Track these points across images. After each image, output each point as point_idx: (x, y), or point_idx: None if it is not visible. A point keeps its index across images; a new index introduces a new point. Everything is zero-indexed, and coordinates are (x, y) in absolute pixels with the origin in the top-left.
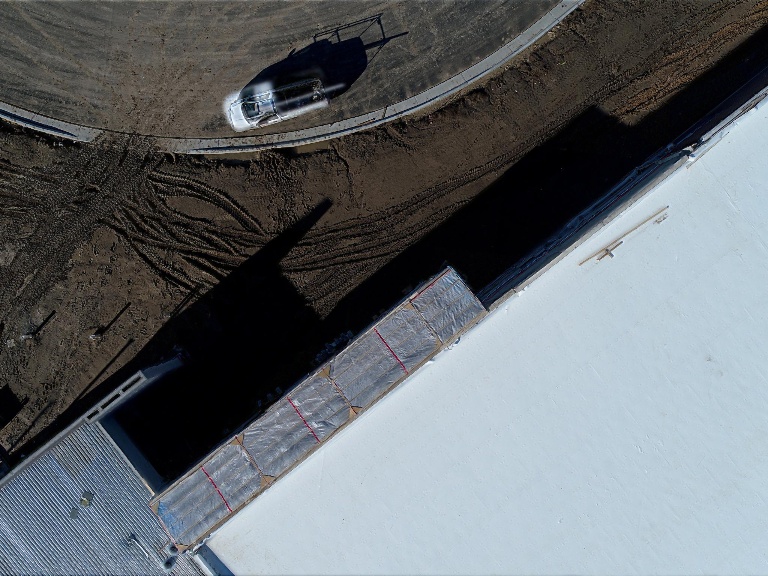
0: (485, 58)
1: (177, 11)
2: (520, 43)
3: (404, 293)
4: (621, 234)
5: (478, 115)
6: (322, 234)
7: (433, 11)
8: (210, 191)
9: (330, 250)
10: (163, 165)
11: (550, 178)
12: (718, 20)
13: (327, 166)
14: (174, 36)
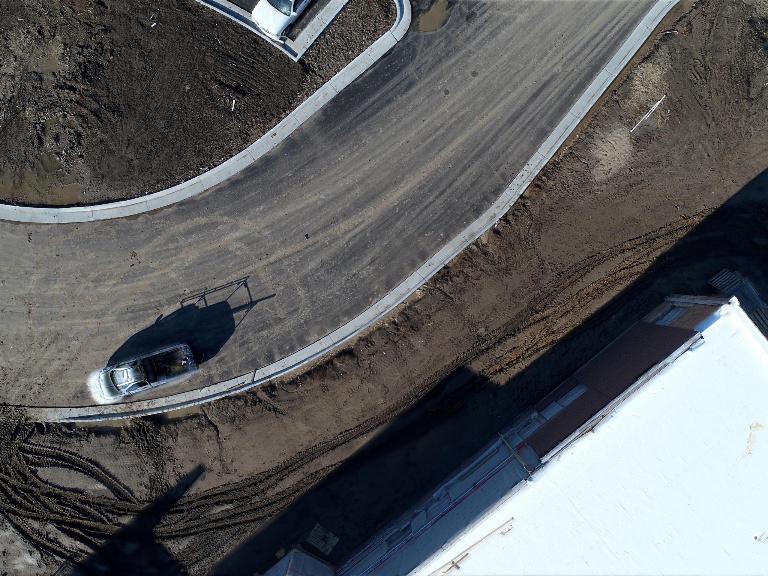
0: (353, 319)
1: (43, 280)
2: (388, 303)
3: (277, 556)
4: (466, 546)
5: (346, 378)
6: (194, 501)
7: (300, 273)
8: (81, 461)
9: (202, 516)
10: (34, 436)
11: (420, 439)
12: (585, 277)
13: (197, 432)
14: (40, 305)
